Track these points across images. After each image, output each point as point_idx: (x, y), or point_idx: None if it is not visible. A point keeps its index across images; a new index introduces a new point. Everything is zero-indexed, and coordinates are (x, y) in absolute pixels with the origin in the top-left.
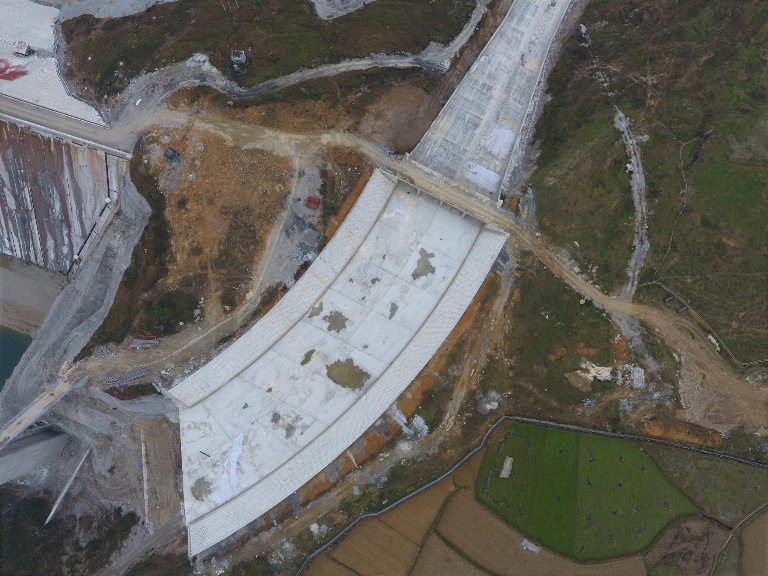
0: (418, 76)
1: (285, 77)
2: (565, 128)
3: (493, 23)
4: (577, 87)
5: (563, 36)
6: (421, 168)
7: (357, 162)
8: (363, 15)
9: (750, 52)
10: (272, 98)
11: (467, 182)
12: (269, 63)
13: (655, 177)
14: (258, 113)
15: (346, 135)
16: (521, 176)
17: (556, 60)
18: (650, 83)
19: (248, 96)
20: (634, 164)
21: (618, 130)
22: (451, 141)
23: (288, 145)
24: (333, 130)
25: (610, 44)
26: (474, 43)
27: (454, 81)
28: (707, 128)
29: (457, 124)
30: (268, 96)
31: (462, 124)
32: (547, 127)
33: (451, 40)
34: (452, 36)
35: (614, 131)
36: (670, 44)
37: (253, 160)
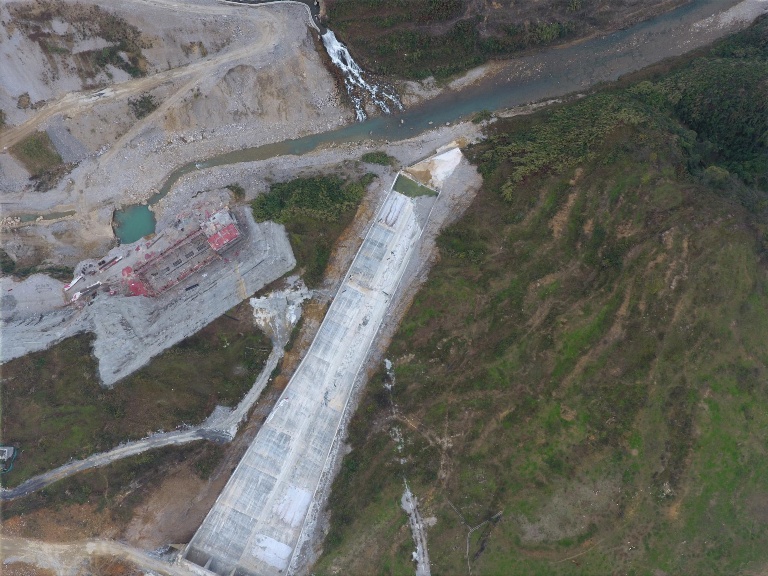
0: (199, 453)
1: (53, 471)
2: (353, 504)
3: (296, 357)
4: (372, 447)
5: (370, 367)
6: (194, 570)
7: (124, 572)
8: (146, 377)
9: (550, 409)
10: (34, 506)
11: (255, 561)
12: (38, 453)
13: (440, 569)
14: (19, 525)
15: (112, 543)
16: (309, 555)
17: (359, 401)
18: (445, 446)
19: (14, 496)
20: (420, 553)
21: (405, 511)
22: (240, 511)
23: (52, 556)
24: (98, 538)
25: (412, 388)
26: (268, 394)
27: (246, 440)
28: (498, 508)
29: (248, 489)
30: (28, 506)
31: (254, 488)
32: (340, 494)
33: (240, 400)
34: (241, 395)
35: (401, 512)
36: (471, 394)
37: (15, 575)
